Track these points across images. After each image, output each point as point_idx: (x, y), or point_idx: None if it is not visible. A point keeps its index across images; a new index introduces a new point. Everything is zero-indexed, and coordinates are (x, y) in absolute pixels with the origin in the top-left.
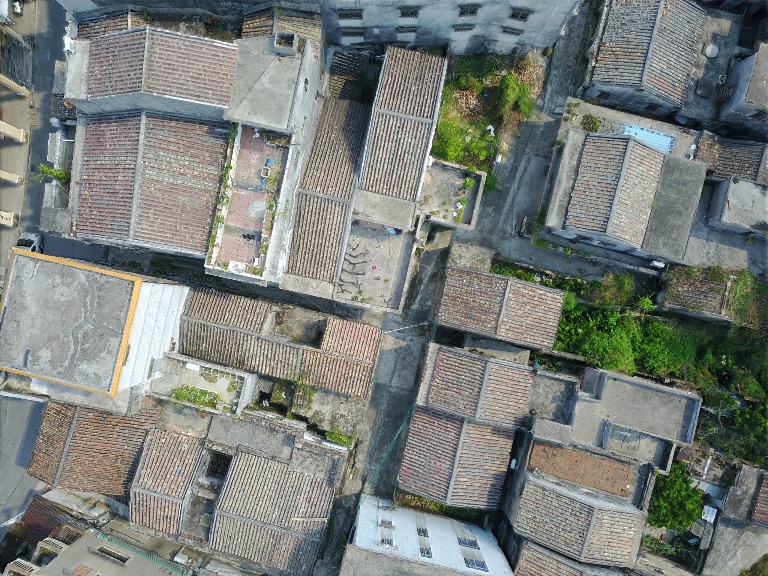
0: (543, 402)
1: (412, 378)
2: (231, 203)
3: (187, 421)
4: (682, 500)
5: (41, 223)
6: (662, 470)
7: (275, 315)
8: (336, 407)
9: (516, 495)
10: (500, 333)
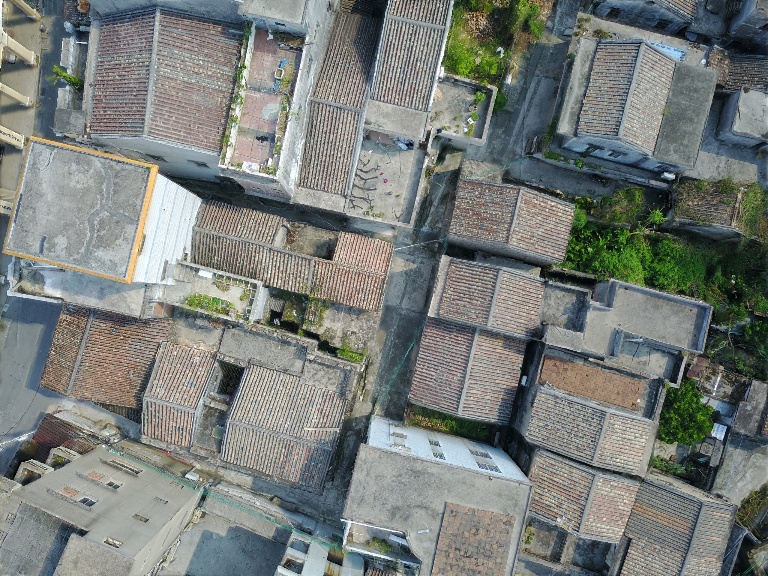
0: (554, 314)
1: (422, 300)
2: (245, 105)
3: (199, 335)
4: (693, 412)
5: (55, 124)
6: (673, 383)
7: (286, 233)
8: (347, 324)
9: (527, 407)
10: (512, 242)
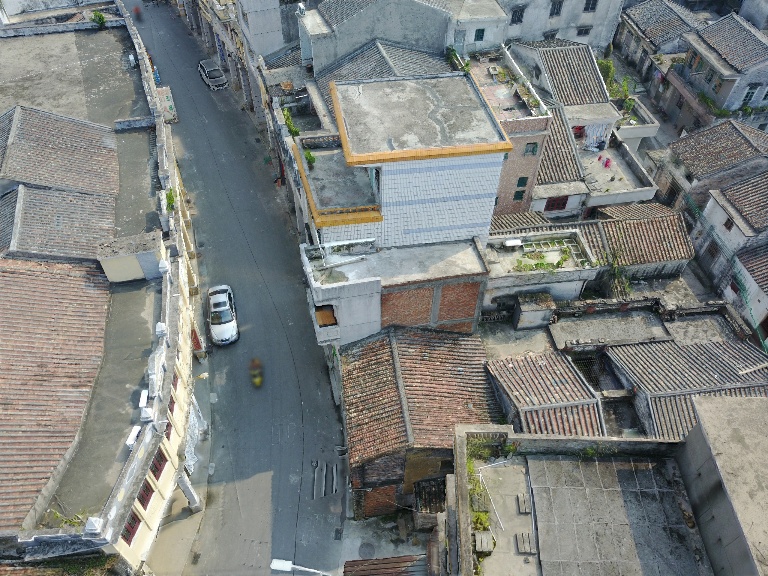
0: None
1: (697, 283)
2: None
3: (520, 347)
4: None
5: None
6: None
7: None
8: None
9: None
10: None
